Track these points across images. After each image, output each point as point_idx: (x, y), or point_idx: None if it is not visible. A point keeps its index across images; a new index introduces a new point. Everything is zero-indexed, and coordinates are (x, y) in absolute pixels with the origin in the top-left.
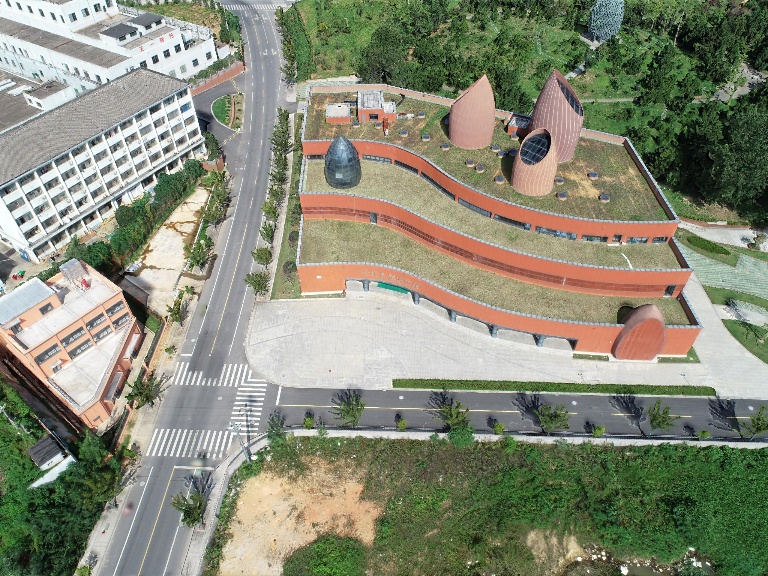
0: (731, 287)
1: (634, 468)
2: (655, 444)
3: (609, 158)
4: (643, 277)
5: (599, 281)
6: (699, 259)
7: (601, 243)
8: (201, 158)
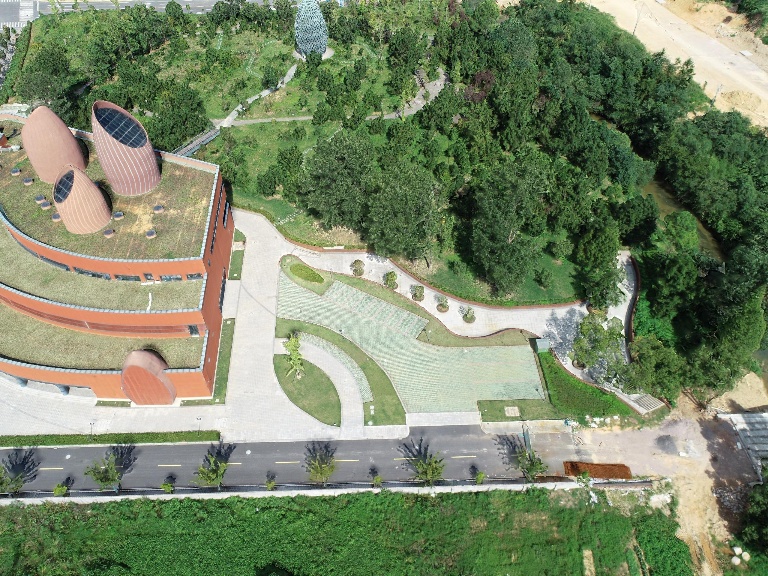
0: (304, 318)
1: (81, 529)
2: (118, 500)
3: (191, 188)
4: (154, 319)
5: (116, 324)
6: (290, 288)
7: (136, 282)
8: None
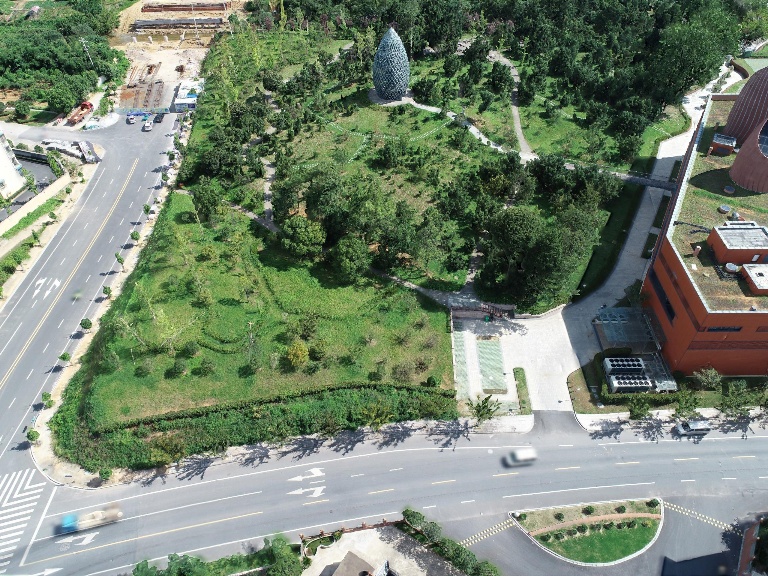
0: None
1: None
2: None
3: None
4: None
5: None
6: None
7: None
8: None
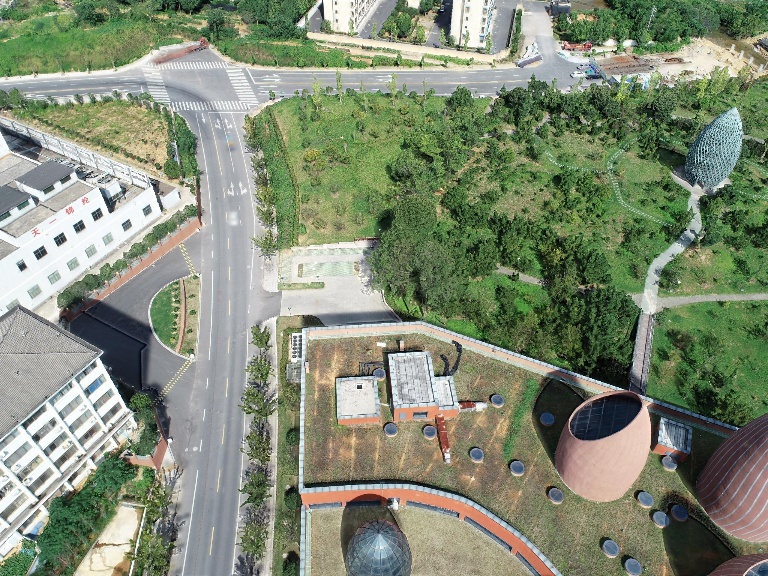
0: None
1: None
2: None
3: None
4: None
5: None
6: None
7: None
8: (127, 441)
